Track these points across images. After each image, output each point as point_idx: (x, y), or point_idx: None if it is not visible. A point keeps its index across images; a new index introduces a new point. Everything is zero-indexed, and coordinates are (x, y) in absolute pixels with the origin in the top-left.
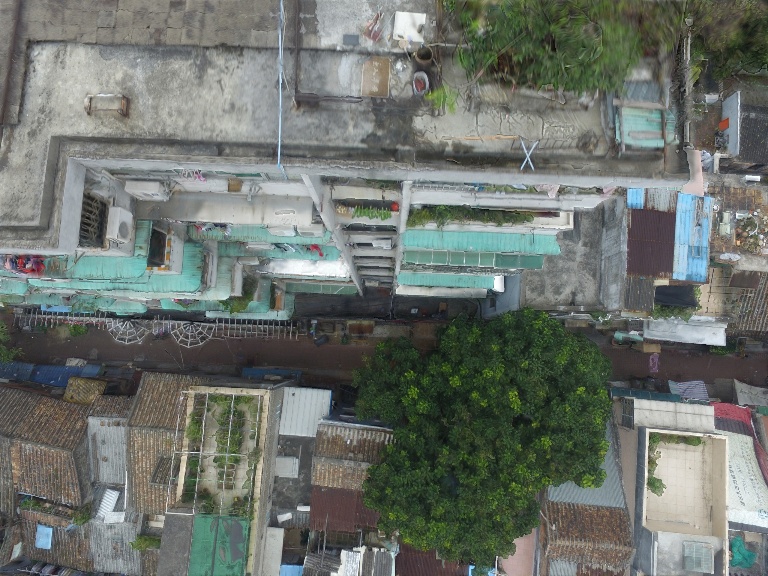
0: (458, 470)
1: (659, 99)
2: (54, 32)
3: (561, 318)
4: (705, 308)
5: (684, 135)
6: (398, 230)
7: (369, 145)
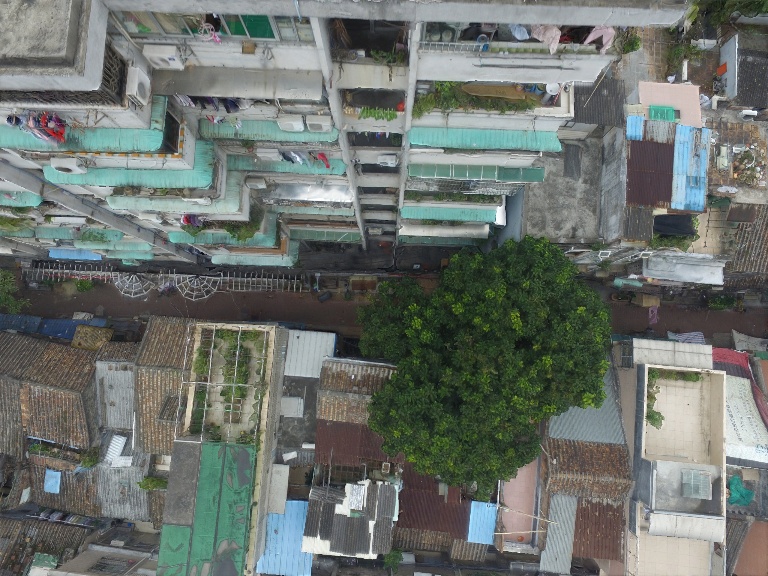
0: (461, 389)
1: None
2: None
3: None
4: None
5: (682, 73)
6: (403, 129)
7: None
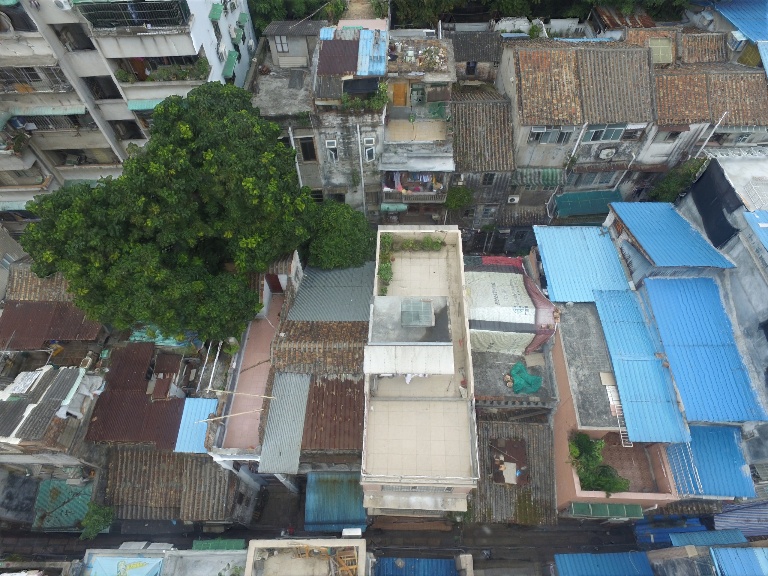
0: None
1: None
2: None
3: (323, 189)
4: None
5: None
6: None
7: None
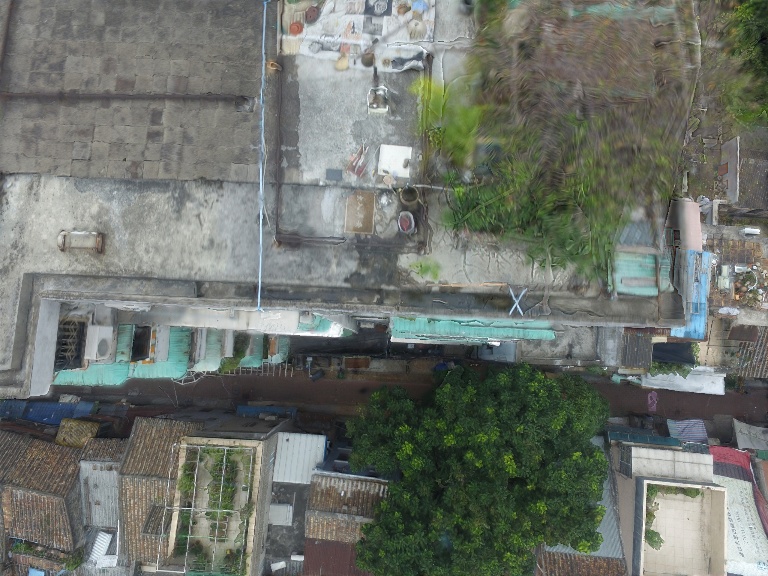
0: (452, 535)
1: (653, 242)
2: (27, 164)
3: None
4: (704, 357)
5: (682, 185)
6: None
7: (353, 285)
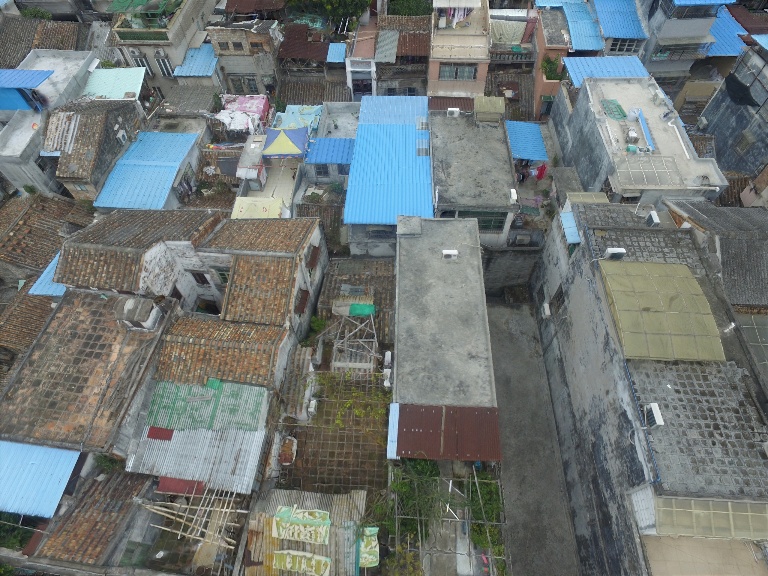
0: None
1: None
2: None
3: None
4: None
5: None
6: None
7: None
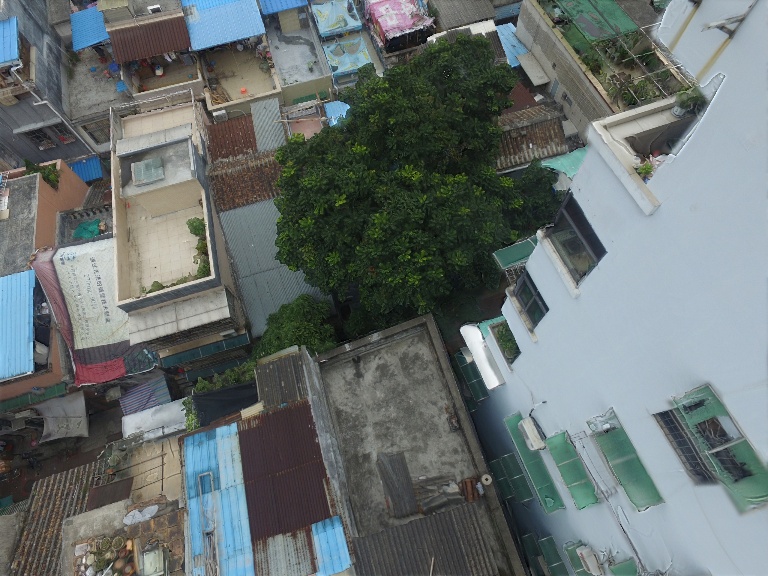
0: (440, 99)
1: None
2: None
3: None
4: None
5: None
6: None
7: None
